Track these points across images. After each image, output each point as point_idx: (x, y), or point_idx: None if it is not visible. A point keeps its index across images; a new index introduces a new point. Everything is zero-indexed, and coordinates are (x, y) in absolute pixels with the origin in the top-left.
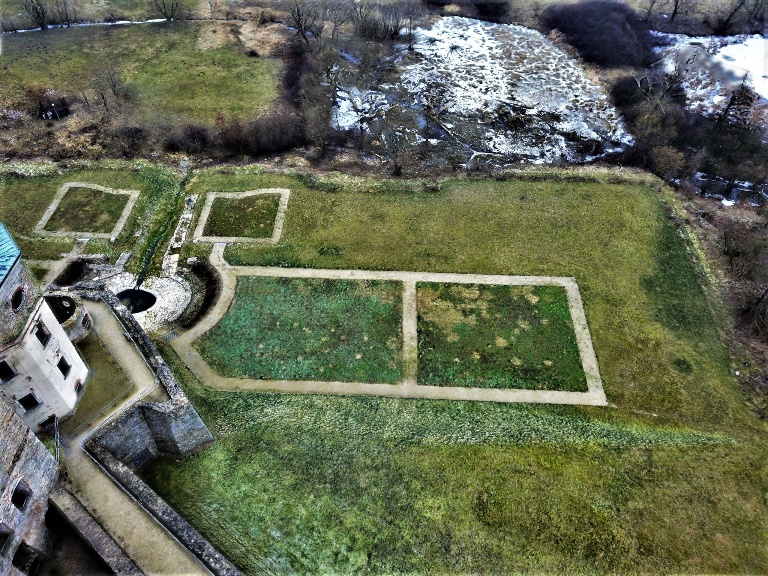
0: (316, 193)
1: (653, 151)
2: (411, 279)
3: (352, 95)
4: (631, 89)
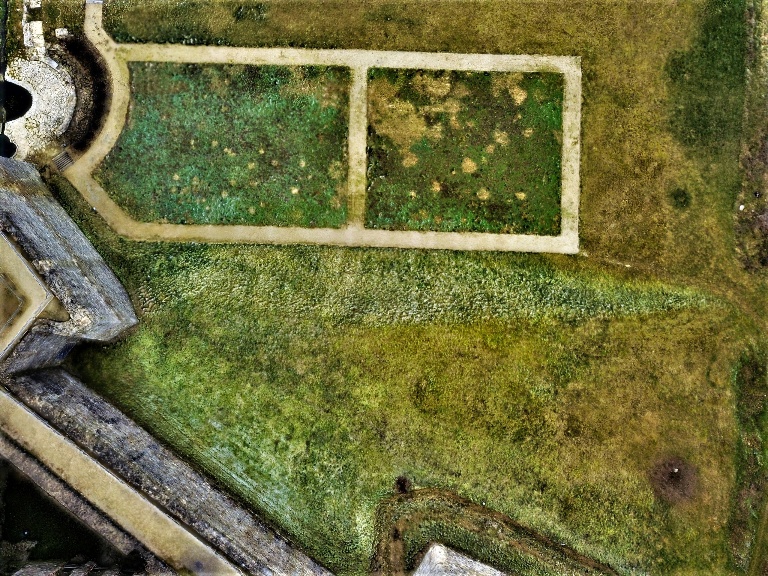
0: None
1: None
2: (361, 64)
3: None
4: None
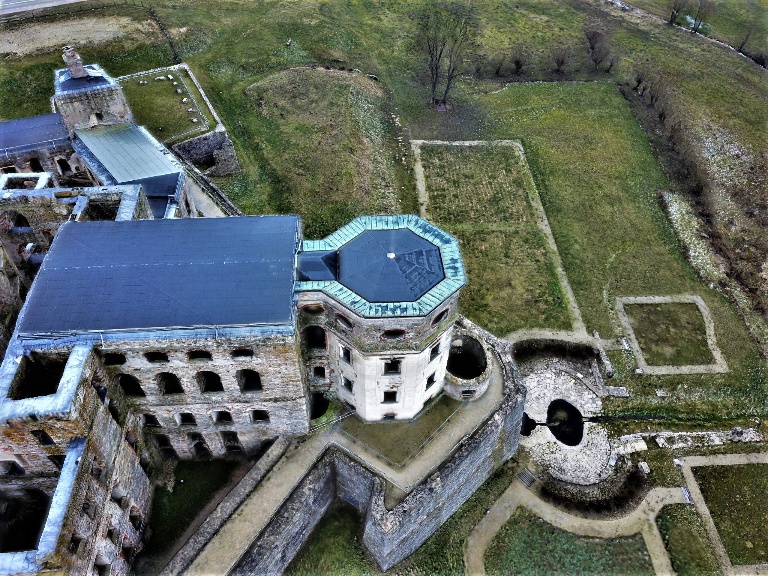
0: None
1: None
2: None
3: None
4: None
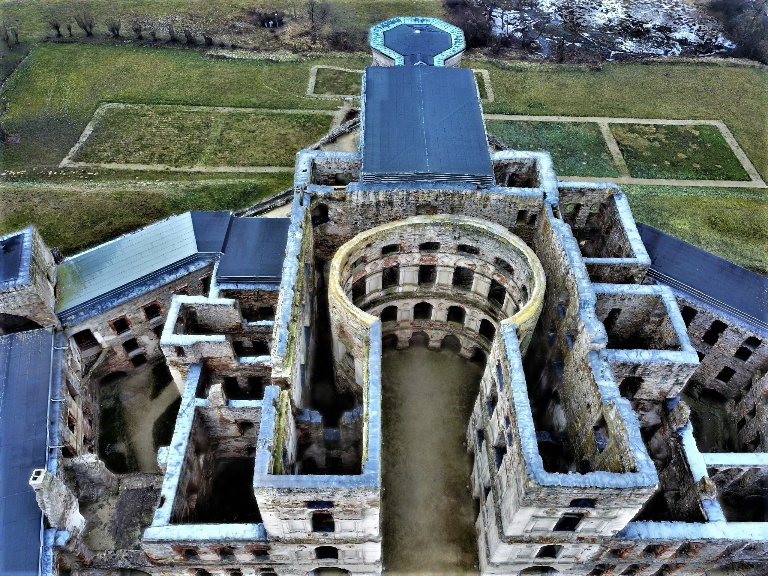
0: (508, 72)
1: (759, 44)
2: (603, 121)
3: (523, 3)
4: (726, 7)
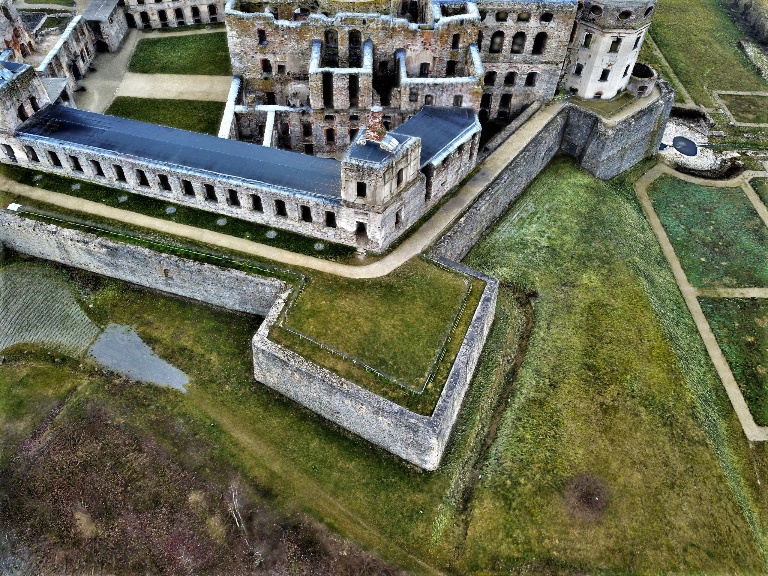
0: None
1: None
2: None
3: None
4: None
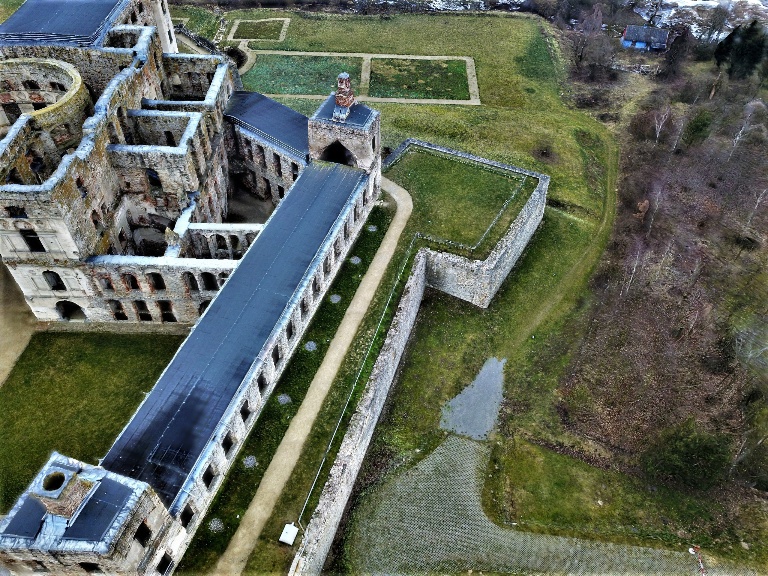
0: (308, 20)
1: None
2: (368, 56)
3: None
4: None
